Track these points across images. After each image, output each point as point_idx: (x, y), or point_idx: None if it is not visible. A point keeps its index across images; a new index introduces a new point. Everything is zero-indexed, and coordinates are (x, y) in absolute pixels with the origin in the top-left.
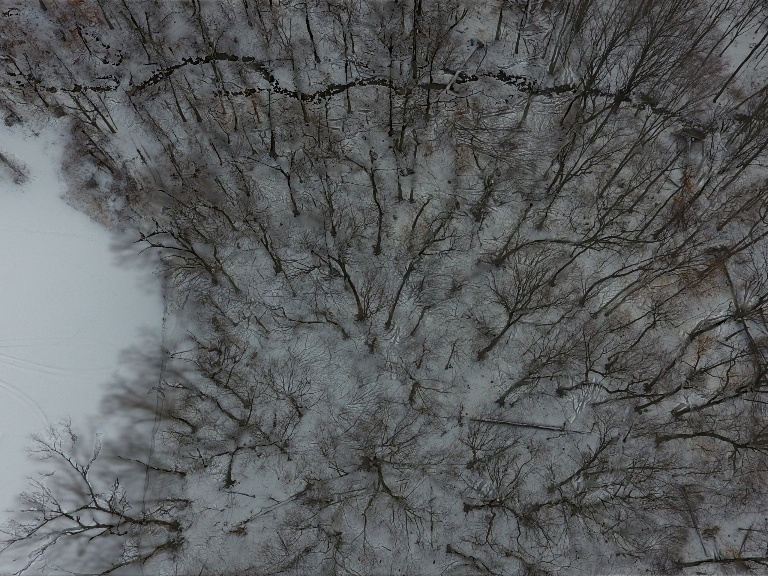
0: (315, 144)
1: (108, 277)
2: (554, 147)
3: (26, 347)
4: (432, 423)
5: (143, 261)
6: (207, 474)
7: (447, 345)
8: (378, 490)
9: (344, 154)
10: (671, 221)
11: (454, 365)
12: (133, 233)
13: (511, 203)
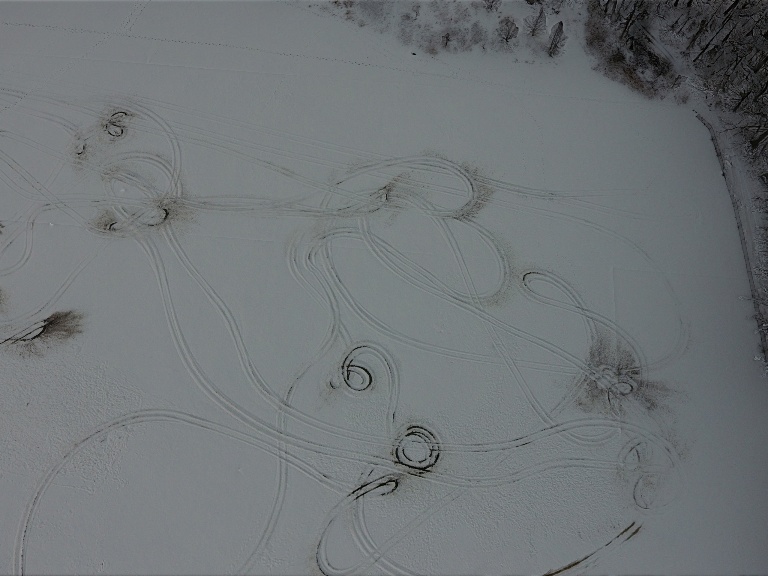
0: None
1: (660, 138)
2: None
3: (608, 196)
4: None
5: (686, 125)
6: None
7: None
8: None
9: None
10: None
11: None
12: (669, 101)
13: None
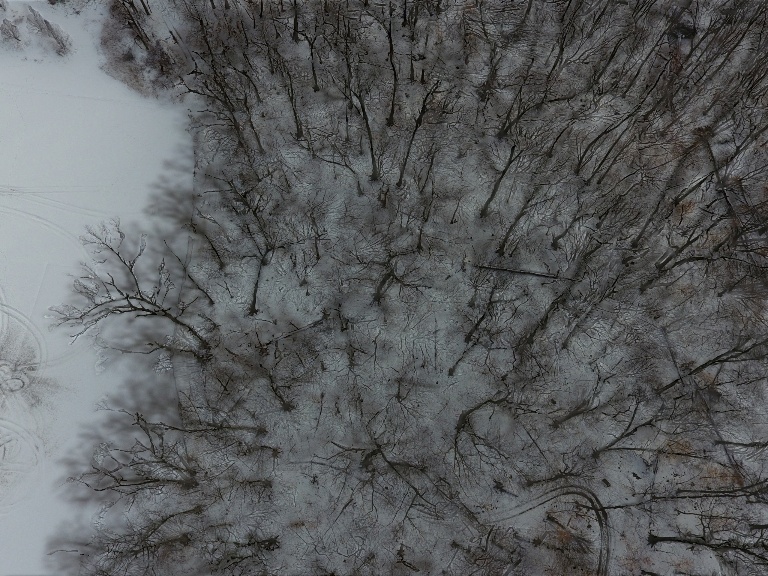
0: (334, 31)
1: (143, 137)
2: (555, 40)
3: (69, 193)
4: (438, 268)
5: (175, 124)
6: (233, 303)
7: (453, 199)
8: (392, 283)
9: (361, 40)
10: (660, 101)
11: (459, 220)
12: (166, 100)
13: (514, 86)
